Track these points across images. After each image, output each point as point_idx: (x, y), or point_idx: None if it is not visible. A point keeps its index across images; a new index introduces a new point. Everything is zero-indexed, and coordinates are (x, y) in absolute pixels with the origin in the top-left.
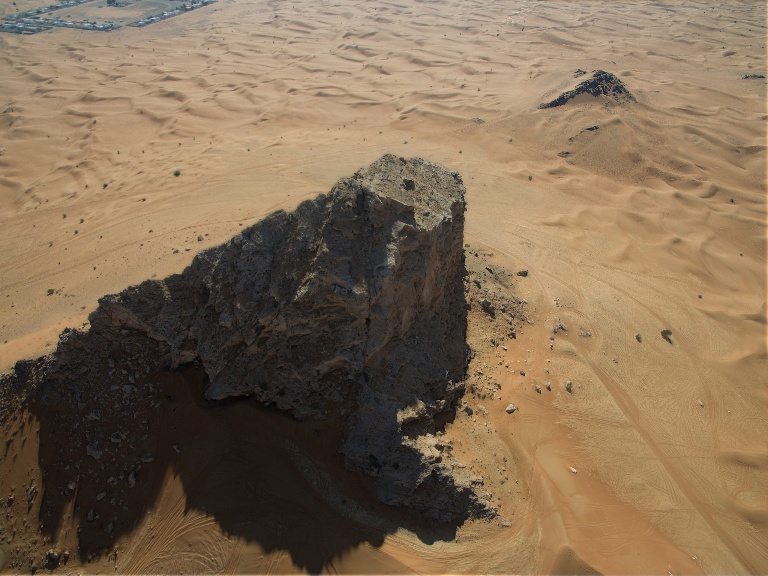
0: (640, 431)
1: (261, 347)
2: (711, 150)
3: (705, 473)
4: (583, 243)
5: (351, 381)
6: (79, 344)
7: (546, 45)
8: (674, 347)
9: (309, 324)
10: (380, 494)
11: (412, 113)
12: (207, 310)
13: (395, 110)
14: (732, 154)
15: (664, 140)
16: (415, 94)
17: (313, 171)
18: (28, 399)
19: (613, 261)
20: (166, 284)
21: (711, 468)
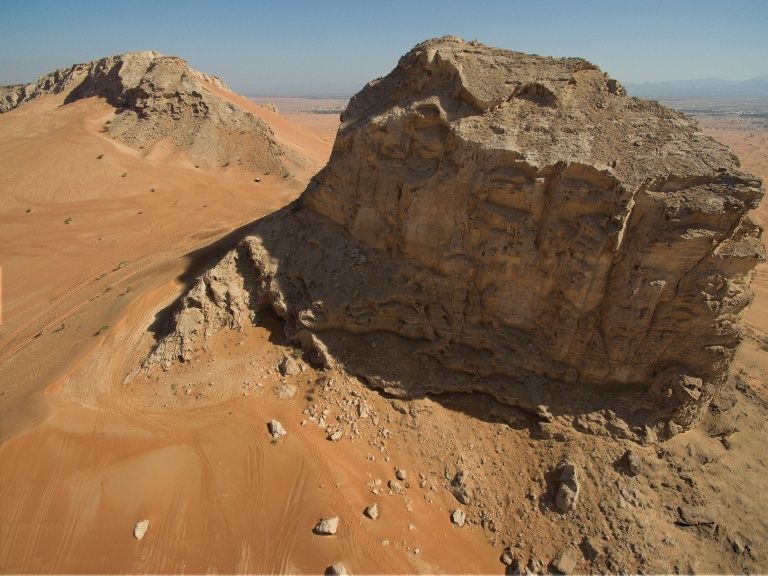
0: None
1: None
2: None
3: None
4: None
5: None
6: None
7: None
8: None
9: None
10: None
11: None
12: None
13: None
14: None
15: None
16: None
17: None
18: None
19: None
20: None
21: None
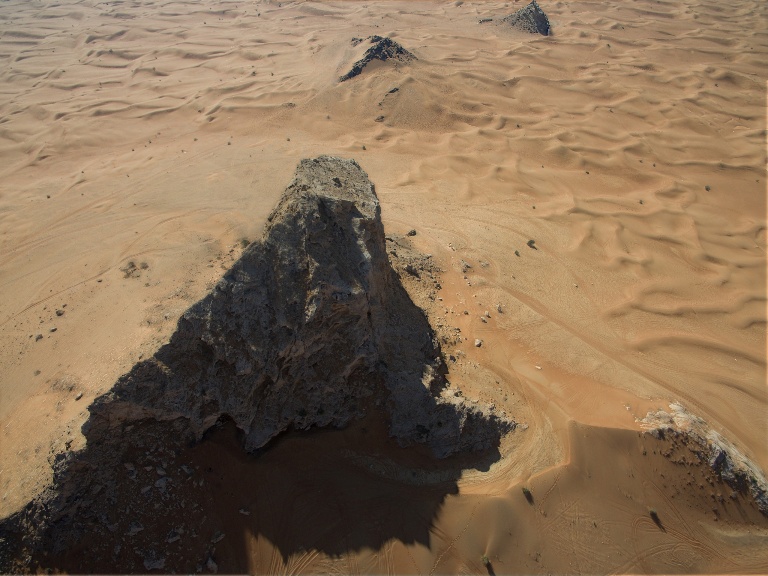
0: (555, 321)
1: (285, 379)
2: (487, 89)
3: (603, 332)
4: (437, 192)
5: (373, 373)
6: (80, 465)
7: (310, 18)
8: (540, 252)
9: (321, 339)
10: (436, 453)
11: (218, 112)
12: (216, 367)
13: (197, 112)
14: (502, 89)
15: (452, 88)
16: (210, 91)
17: (148, 199)
18: (35, 556)
19: (466, 200)
20: (158, 360)
21: (604, 327)
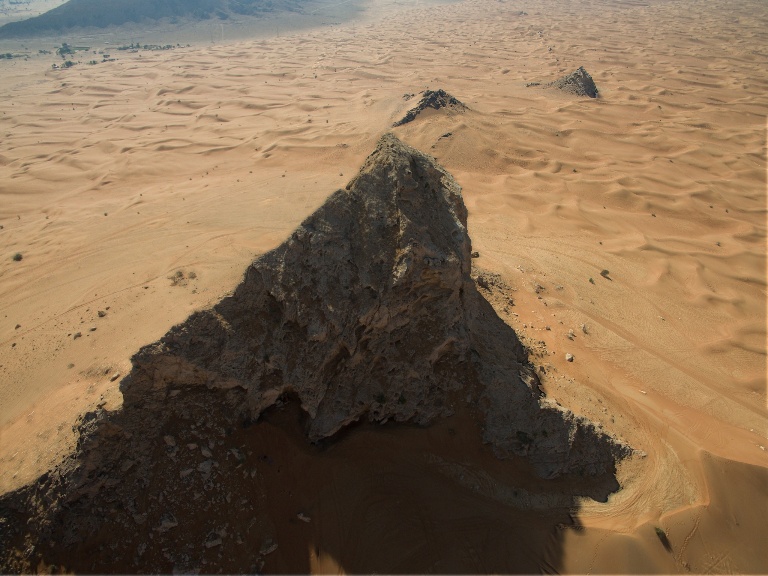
0: (647, 350)
1: (363, 354)
2: (540, 138)
3: (705, 366)
4: (496, 224)
5: (463, 363)
6: (111, 431)
7: (363, 80)
8: (615, 283)
9: (407, 311)
10: (540, 471)
11: (274, 150)
12: (284, 329)
13: (254, 150)
14: (555, 138)
15: (505, 135)
16: (268, 133)
17: (201, 218)
18: (39, 547)
19: (527, 232)
20: (218, 313)
21: (704, 362)
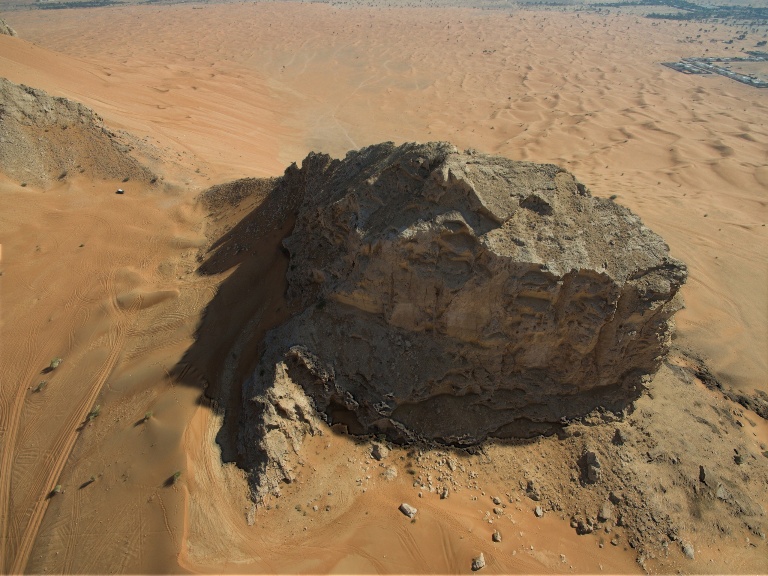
0: None
1: None
2: None
3: None
4: None
5: None
6: None
7: None
8: None
9: None
10: (247, 380)
11: None
12: None
13: None
14: None
15: None
16: None
17: (732, 264)
18: None
19: None
20: (332, 162)
21: None
